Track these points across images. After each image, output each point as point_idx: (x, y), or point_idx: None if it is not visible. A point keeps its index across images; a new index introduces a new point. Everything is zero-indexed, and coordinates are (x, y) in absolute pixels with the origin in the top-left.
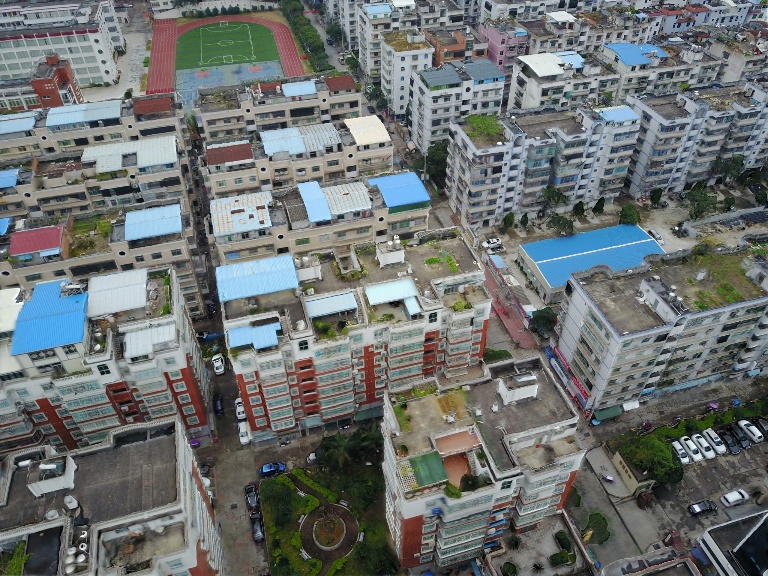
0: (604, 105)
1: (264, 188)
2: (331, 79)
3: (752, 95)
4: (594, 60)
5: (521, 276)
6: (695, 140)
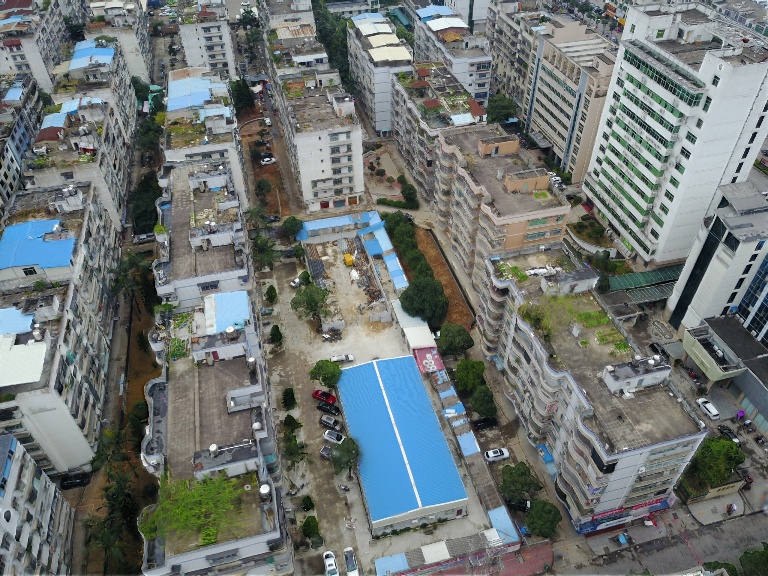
0: (171, 320)
1: None
2: None
3: (206, 186)
4: None
5: (408, 537)
6: None
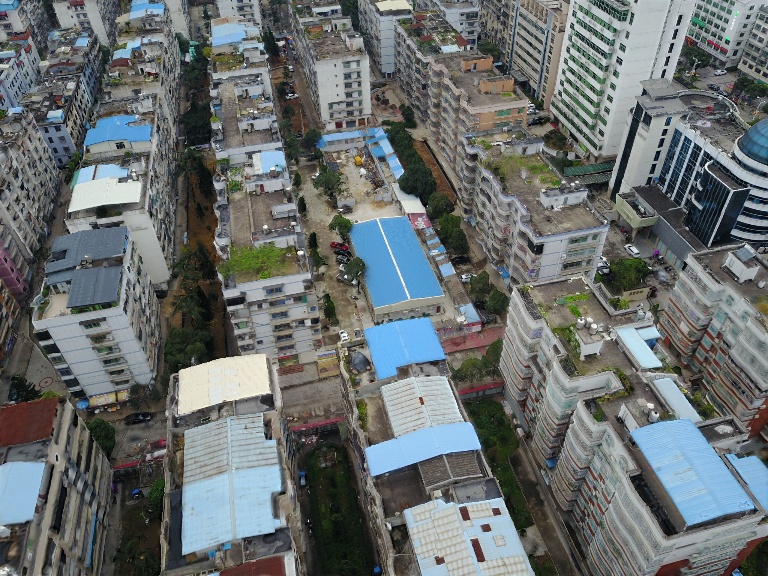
0: (228, 171)
1: (300, 569)
2: (1, 437)
3: (248, 94)
4: (98, 163)
5: None
6: None
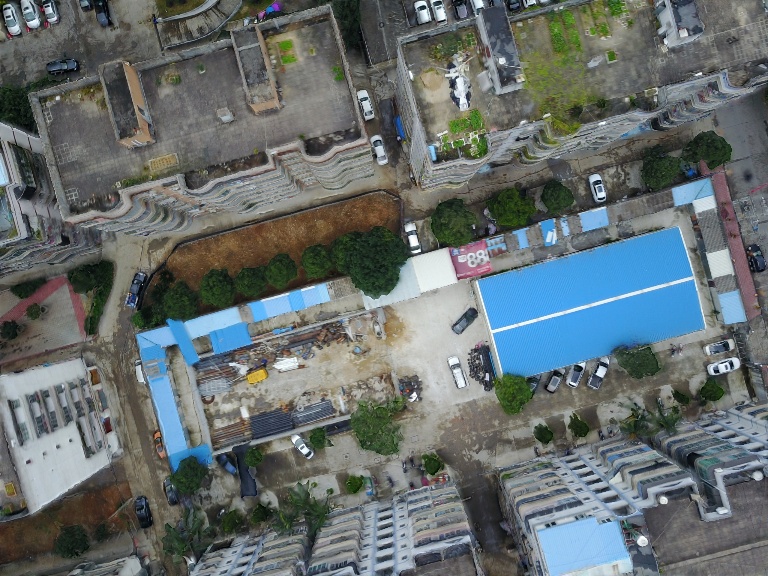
0: None
1: None
2: None
3: None
4: None
5: None
6: (374, 548)
